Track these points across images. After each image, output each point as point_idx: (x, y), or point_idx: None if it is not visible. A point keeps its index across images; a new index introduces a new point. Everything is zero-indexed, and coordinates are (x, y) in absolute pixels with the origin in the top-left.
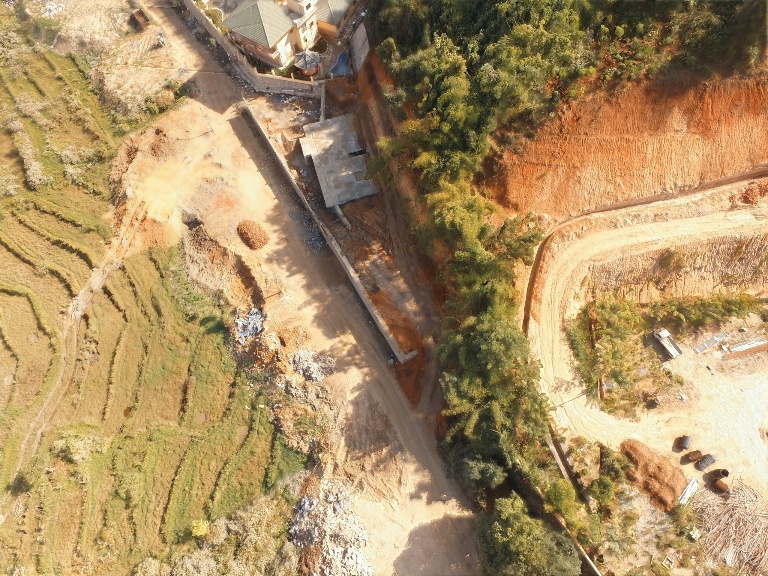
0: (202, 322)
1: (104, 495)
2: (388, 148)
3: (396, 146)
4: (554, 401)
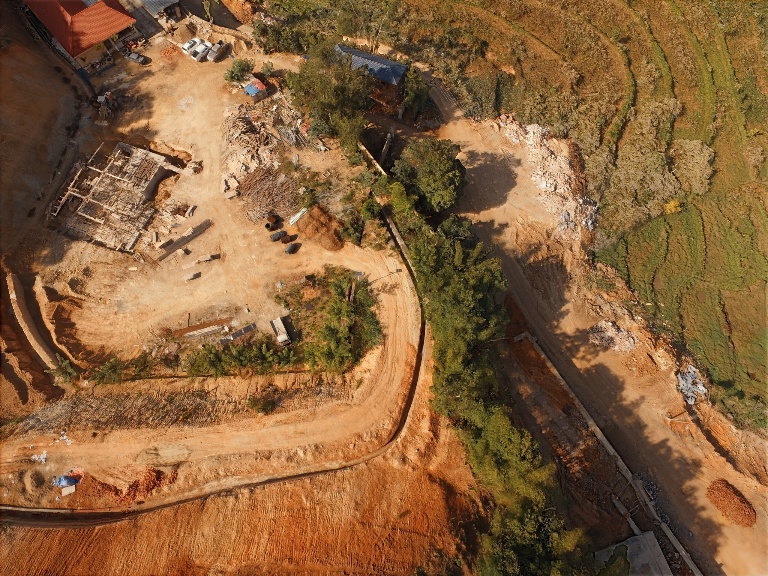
0: (742, 395)
1: (761, 238)
2: (620, 568)
3: (609, 572)
4: (398, 277)
